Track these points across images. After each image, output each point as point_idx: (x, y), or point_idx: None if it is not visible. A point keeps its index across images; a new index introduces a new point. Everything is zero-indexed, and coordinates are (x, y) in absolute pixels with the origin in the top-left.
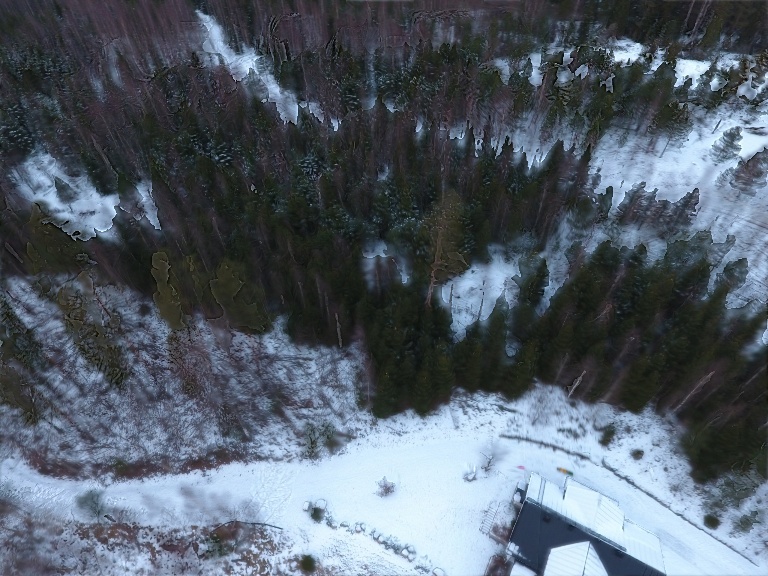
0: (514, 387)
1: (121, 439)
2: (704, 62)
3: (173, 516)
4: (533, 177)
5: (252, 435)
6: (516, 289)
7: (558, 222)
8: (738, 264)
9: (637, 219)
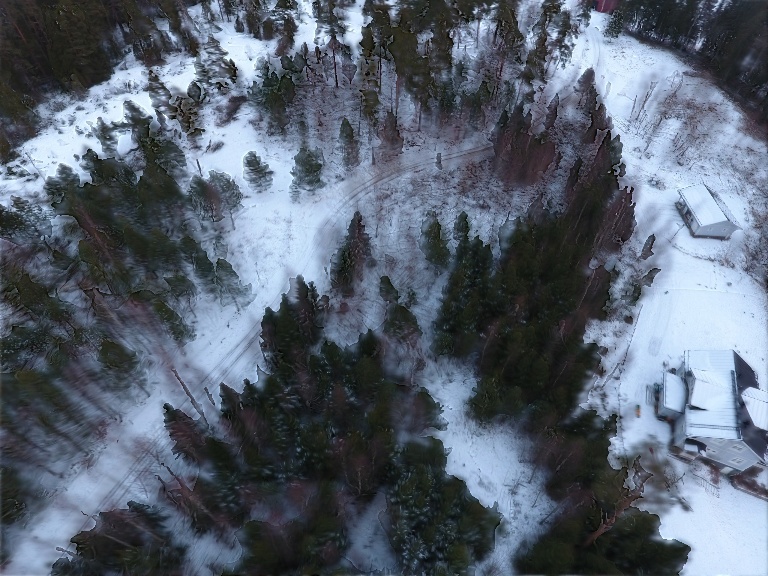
0: (610, 442)
1: None
2: (43, 134)
3: None
4: (329, 362)
5: None
6: (470, 424)
7: (403, 350)
8: (461, 219)
9: (351, 277)
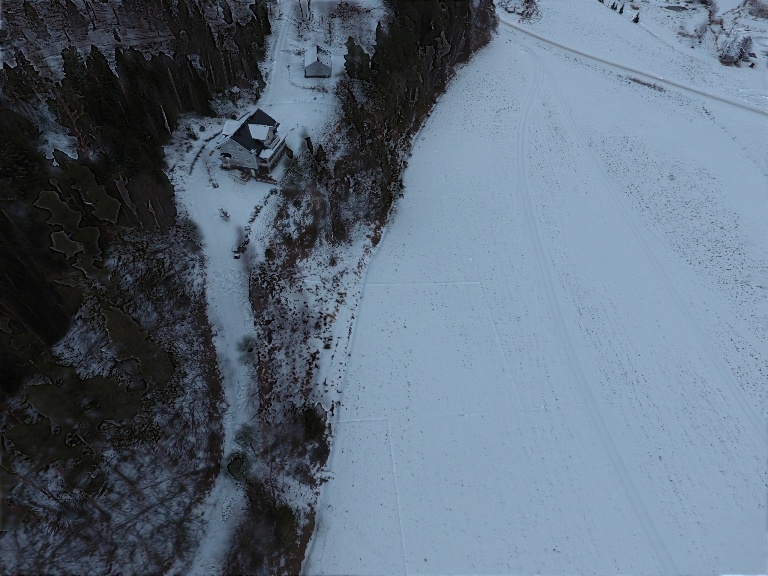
0: (161, 151)
1: (185, 400)
2: None
3: (249, 341)
4: None
5: (185, 298)
6: (74, 149)
7: (20, 105)
8: (93, 50)
9: None
